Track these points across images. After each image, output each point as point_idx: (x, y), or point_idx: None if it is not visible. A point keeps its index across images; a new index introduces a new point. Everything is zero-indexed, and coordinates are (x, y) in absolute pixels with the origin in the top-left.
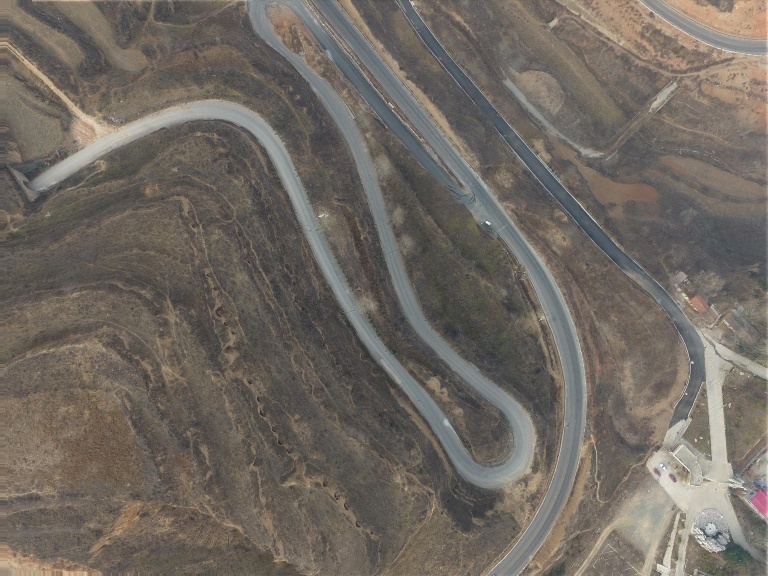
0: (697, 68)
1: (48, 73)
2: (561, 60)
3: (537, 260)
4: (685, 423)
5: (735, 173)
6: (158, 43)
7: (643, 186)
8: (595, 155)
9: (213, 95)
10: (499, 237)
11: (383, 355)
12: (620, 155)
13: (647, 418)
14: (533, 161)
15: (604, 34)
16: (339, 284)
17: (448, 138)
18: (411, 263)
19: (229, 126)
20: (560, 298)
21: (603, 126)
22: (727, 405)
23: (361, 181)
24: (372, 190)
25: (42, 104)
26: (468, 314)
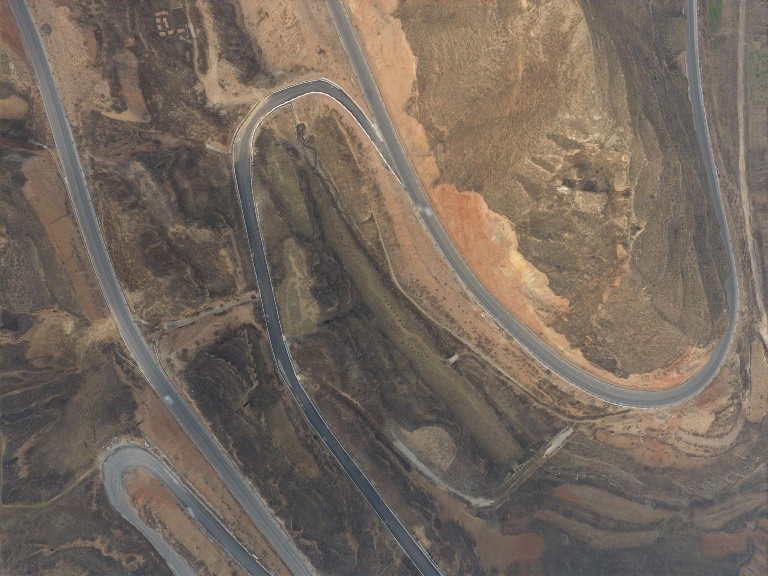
0: (593, 417)
1: None
2: (460, 395)
3: None
4: None
5: (630, 497)
6: (3, 548)
7: (531, 536)
8: (486, 504)
9: None
10: None
11: None
12: (514, 493)
13: None
14: (413, 548)
15: (504, 374)
16: None
17: (316, 573)
18: None
19: None
20: None
21: (500, 460)
22: None
23: None
24: None
25: None
26: None
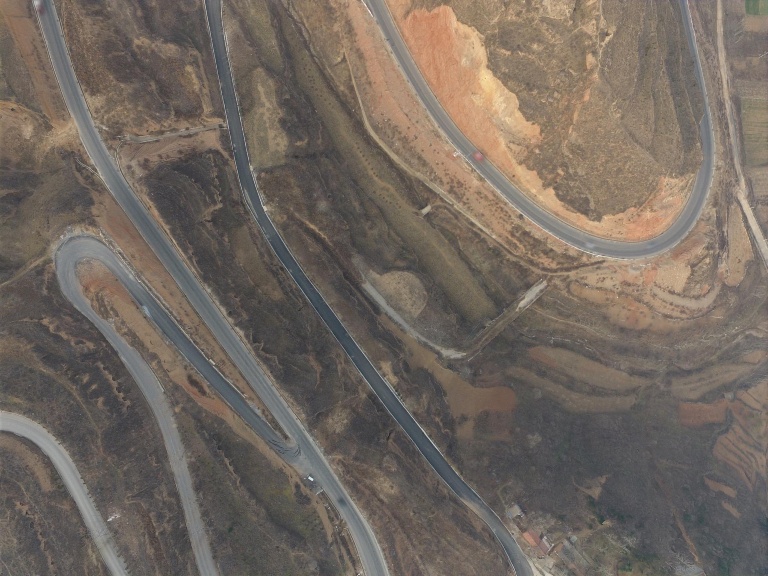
0: (567, 269)
1: None
2: (433, 248)
3: (359, 516)
4: None
5: (606, 362)
6: None
7: (503, 390)
8: (457, 356)
9: None
10: (322, 491)
11: None
12: (486, 350)
13: None
14: (379, 384)
15: (477, 225)
16: None
17: (276, 387)
18: (214, 546)
19: (3, 447)
20: (379, 554)
21: (473, 317)
22: None
23: (168, 458)
24: (179, 467)
25: None
26: None
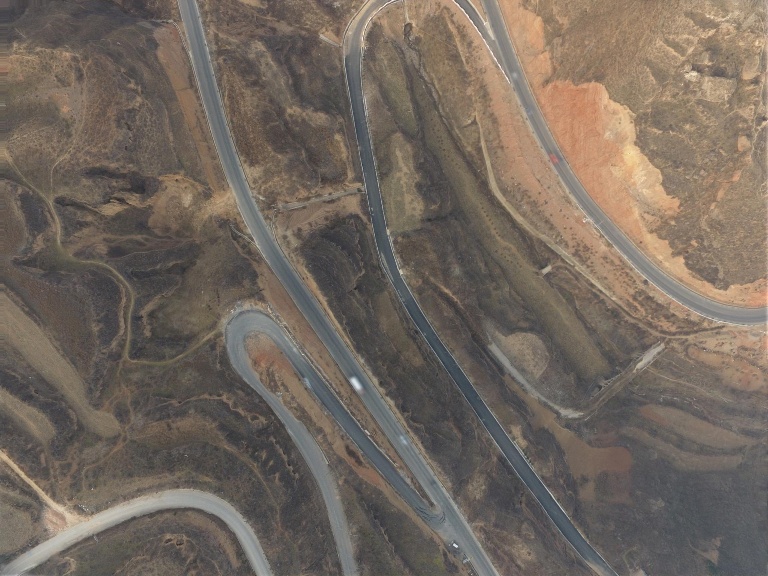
0: (686, 332)
1: (18, 462)
2: (551, 308)
3: None
4: None
5: (713, 421)
6: (132, 398)
7: (618, 450)
8: (574, 415)
9: (184, 483)
10: (465, 557)
11: None
12: None
13: None
14: (509, 447)
15: (597, 286)
16: None
17: (423, 456)
18: None
19: (198, 526)
20: None
21: (587, 375)
22: None
23: (331, 528)
24: (341, 537)
25: (13, 493)
26: None
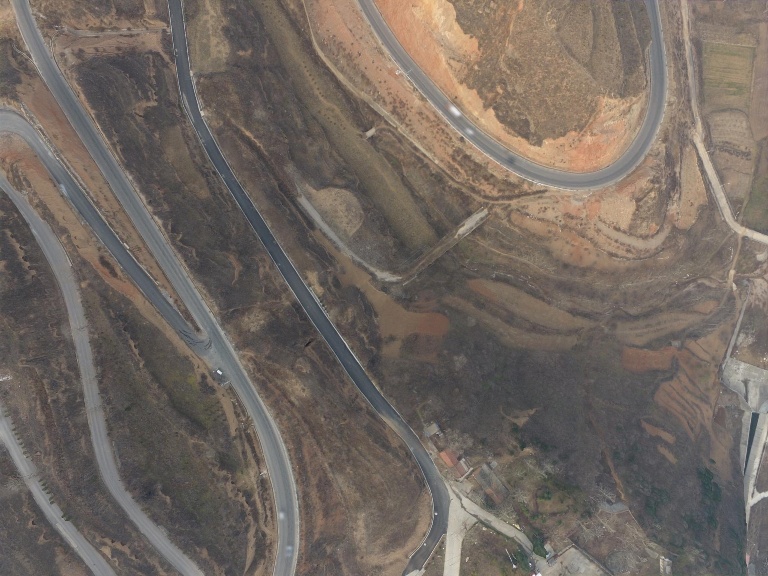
0: (509, 197)
1: None
2: (375, 172)
3: (266, 413)
4: (418, 573)
5: (549, 301)
6: None
7: (436, 316)
8: (392, 279)
9: None
10: (231, 386)
11: (59, 520)
12: (424, 277)
13: (380, 566)
14: (304, 294)
15: (420, 150)
16: (17, 448)
17: (191, 279)
18: (110, 422)
19: None
20: (284, 454)
21: (413, 244)
22: (465, 559)
23: (71, 332)
24: (82, 342)
25: None
26: (173, 472)
